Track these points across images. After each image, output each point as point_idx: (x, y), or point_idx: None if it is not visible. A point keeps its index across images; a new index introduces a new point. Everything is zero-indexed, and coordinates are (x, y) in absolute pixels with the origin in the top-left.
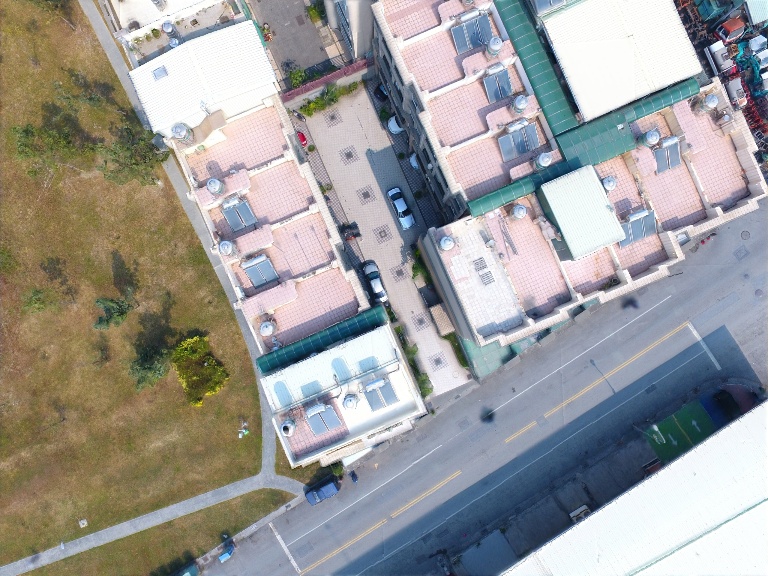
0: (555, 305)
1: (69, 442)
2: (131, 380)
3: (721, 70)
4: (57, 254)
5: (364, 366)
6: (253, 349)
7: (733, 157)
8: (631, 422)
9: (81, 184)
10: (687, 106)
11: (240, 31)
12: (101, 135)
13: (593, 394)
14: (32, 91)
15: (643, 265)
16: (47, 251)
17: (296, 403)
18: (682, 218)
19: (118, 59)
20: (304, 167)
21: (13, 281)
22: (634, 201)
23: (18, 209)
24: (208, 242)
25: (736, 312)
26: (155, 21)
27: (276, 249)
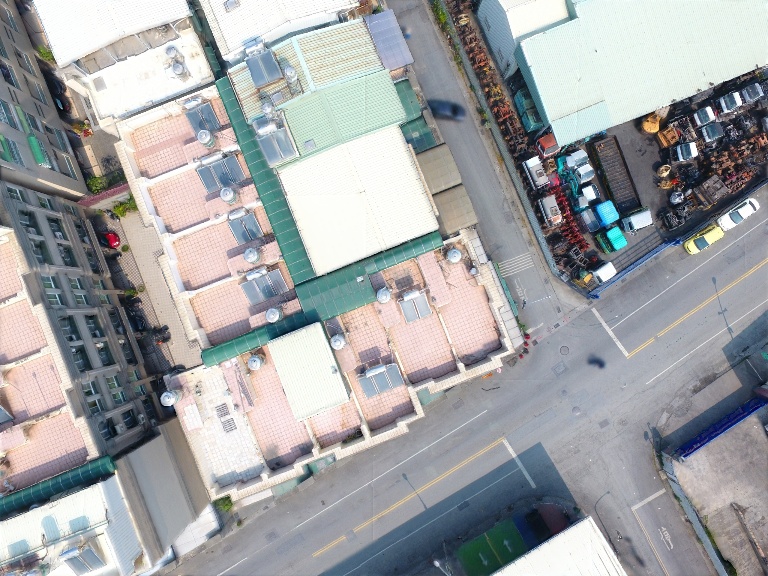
0: (298, 455)
1: None
2: None
3: (536, 186)
4: None
5: (74, 526)
6: None
7: (486, 308)
8: (442, 539)
9: None
10: (433, 258)
11: None
12: None
13: (404, 509)
14: None
15: (390, 416)
16: None
17: (0, 564)
18: (432, 369)
19: None
20: (37, 309)
21: None
22: (383, 350)
23: None
24: None
25: (552, 429)
26: None
27: (13, 388)
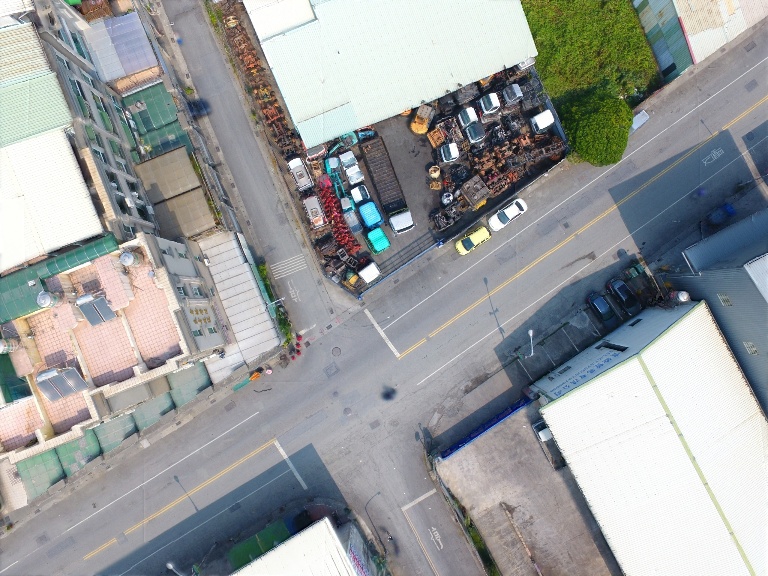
0: None
1: None
2: None
3: (299, 188)
4: None
5: None
6: None
7: None
8: (214, 541)
9: None
10: (110, 261)
11: None
12: None
13: (175, 512)
14: None
15: (76, 420)
16: None
17: None
18: (117, 372)
19: None
20: None
21: None
22: (70, 353)
23: None
24: None
25: (324, 430)
26: None
27: None
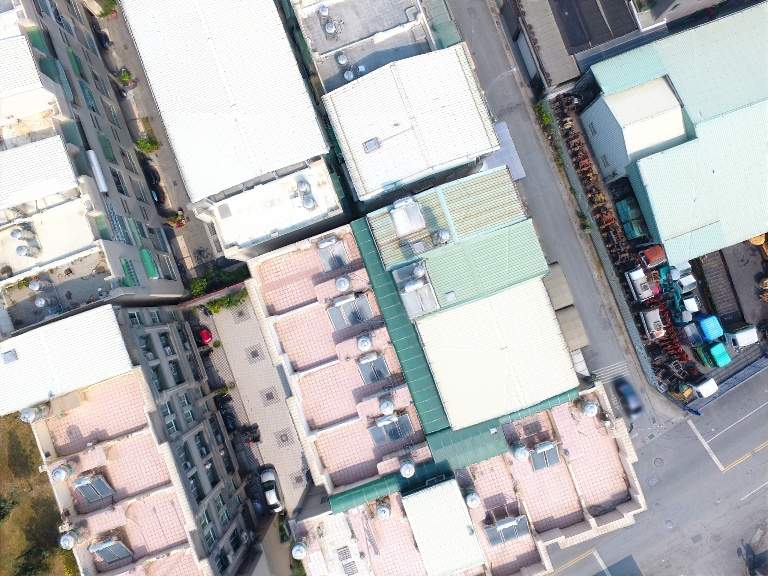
0: None
1: None
2: None
3: (640, 298)
4: None
5: None
6: None
7: (615, 458)
8: None
9: None
10: (567, 409)
11: (97, 316)
12: None
13: None
14: None
15: (514, 565)
16: None
17: None
18: (558, 518)
19: None
20: (163, 447)
21: None
22: (509, 497)
23: None
24: None
25: (644, 542)
26: (26, 271)
27: (133, 523)
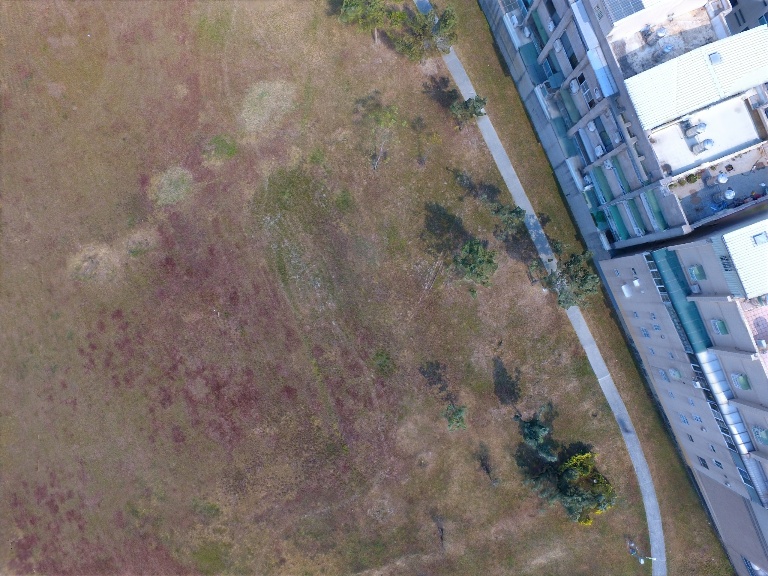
0: None
1: (446, 554)
2: (512, 492)
3: None
4: (437, 359)
5: None
6: (639, 466)
7: None
8: None
9: (463, 287)
10: None
11: None
12: (485, 238)
13: None
14: (415, 190)
15: None
16: (427, 355)
17: None
18: None
19: (505, 161)
20: None
21: (391, 384)
22: None
23: (398, 311)
24: (593, 353)
25: None
26: (696, 167)
27: None
